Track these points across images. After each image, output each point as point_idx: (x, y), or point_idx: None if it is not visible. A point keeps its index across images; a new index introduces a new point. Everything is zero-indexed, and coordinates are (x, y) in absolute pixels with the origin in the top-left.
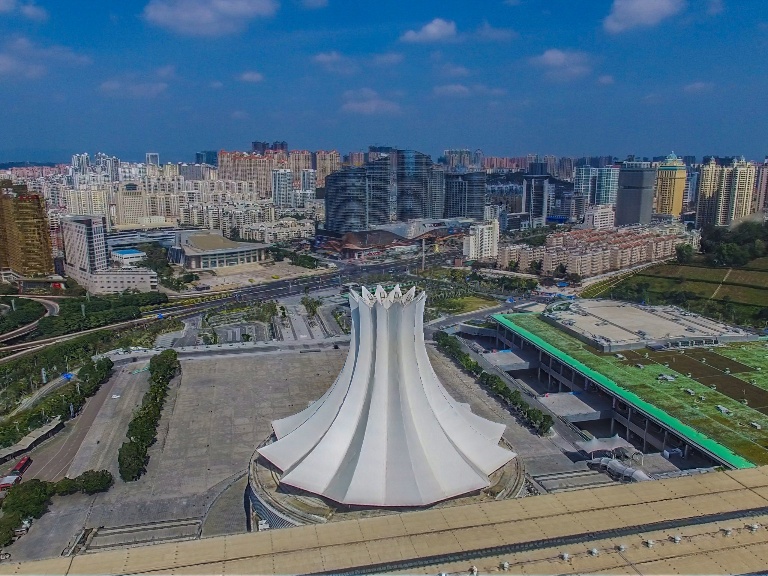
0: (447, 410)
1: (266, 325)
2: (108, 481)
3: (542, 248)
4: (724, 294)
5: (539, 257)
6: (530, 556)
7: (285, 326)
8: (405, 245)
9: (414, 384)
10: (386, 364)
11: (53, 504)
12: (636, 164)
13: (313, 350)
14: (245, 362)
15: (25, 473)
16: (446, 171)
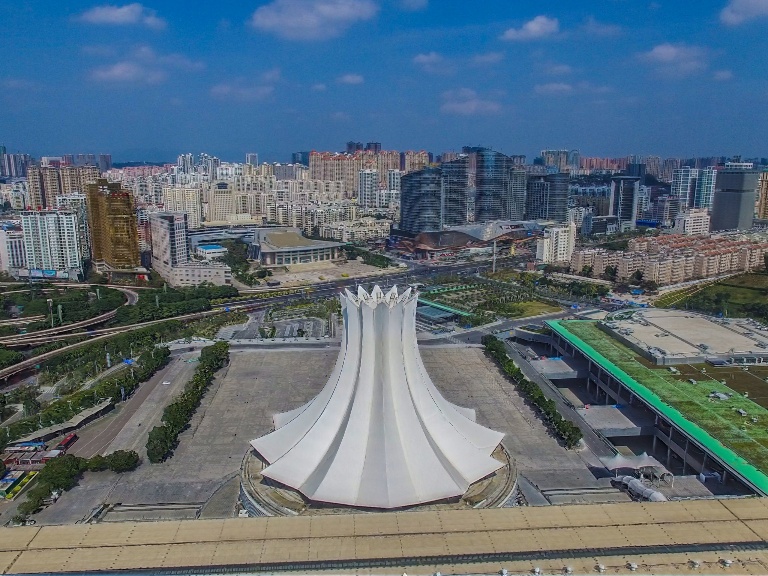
0: (435, 414)
1: (324, 322)
2: (135, 461)
3: (619, 253)
4: None
5: (615, 262)
6: (469, 569)
7: (340, 323)
8: (480, 247)
9: (400, 386)
10: (372, 364)
11: (84, 479)
12: (736, 165)
13: None
14: (292, 357)
15: (70, 448)
16: (528, 172)
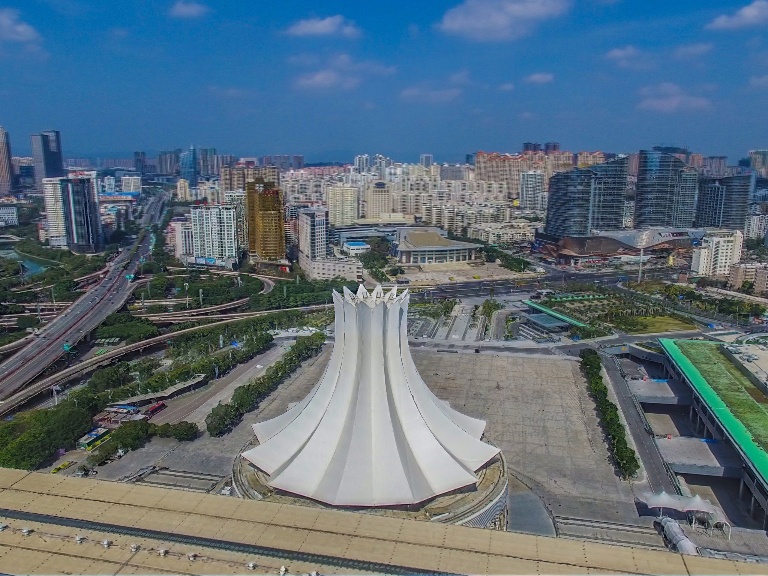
0: (416, 419)
1: (434, 322)
2: (194, 433)
3: None
4: None
5: None
6: (351, 574)
7: (444, 325)
8: (633, 255)
9: (379, 387)
10: (355, 362)
11: (151, 442)
12: None
13: (450, 350)
14: None
15: (156, 415)
16: (701, 174)
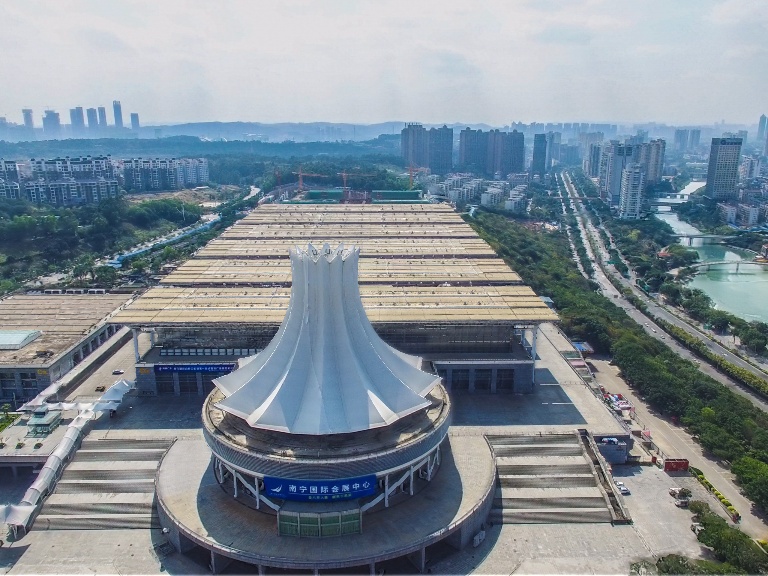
0: None
1: None
2: None
3: None
4: None
5: None
6: None
7: None
8: None
9: None
10: None
11: None
12: None
13: None
14: None
15: None
16: None
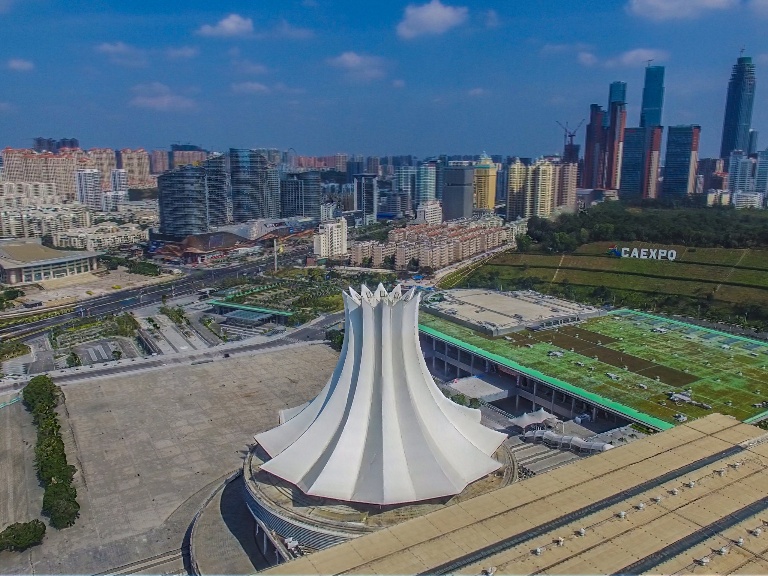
0: (443, 401)
1: (131, 340)
2: (42, 532)
3: (392, 244)
4: (563, 277)
5: (391, 252)
6: (593, 520)
7: (158, 339)
8: (248, 246)
9: (417, 379)
10: (390, 362)
11: None
12: (457, 163)
13: (205, 361)
14: (134, 381)
15: None
16: (280, 170)
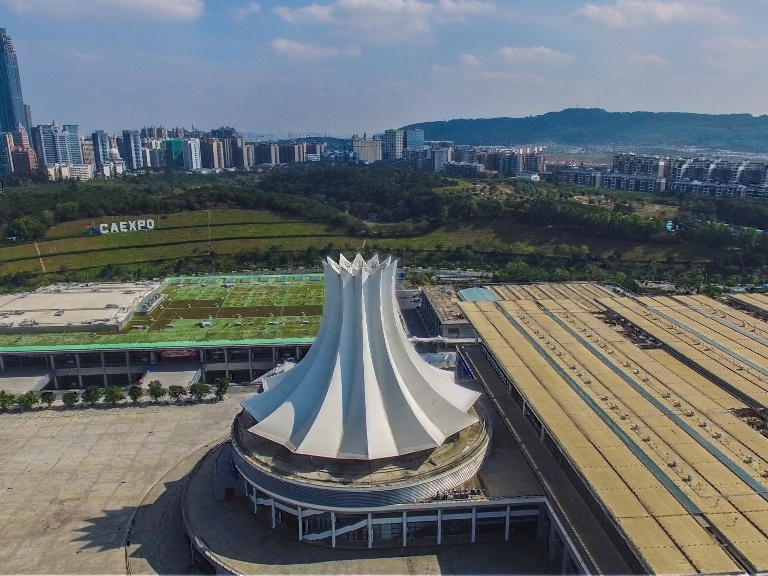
0: None
1: None
2: None
3: None
4: (55, 265)
5: None
6: None
7: None
8: None
9: None
10: None
11: None
12: None
13: None
14: None
15: None
16: None
